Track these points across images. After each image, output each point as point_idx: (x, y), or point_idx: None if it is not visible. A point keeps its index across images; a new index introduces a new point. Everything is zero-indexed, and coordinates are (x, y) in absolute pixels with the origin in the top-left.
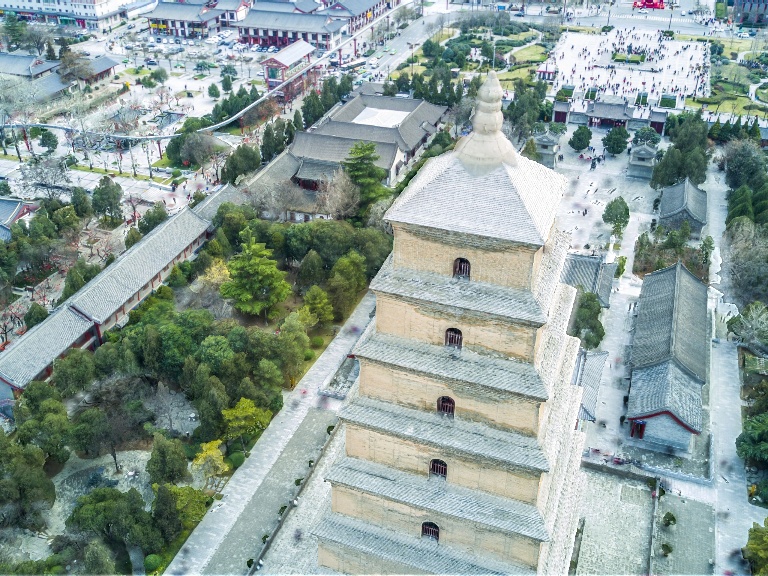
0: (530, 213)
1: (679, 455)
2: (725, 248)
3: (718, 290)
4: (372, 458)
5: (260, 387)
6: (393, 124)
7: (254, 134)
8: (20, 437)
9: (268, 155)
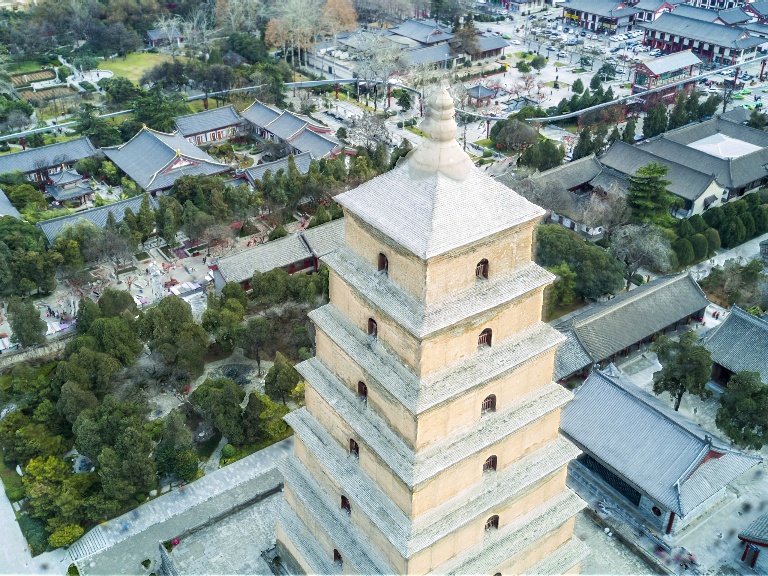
0: (436, 227)
1: None
2: None
3: None
4: (319, 418)
5: None
6: (732, 156)
7: None
8: (202, 319)
9: (578, 157)
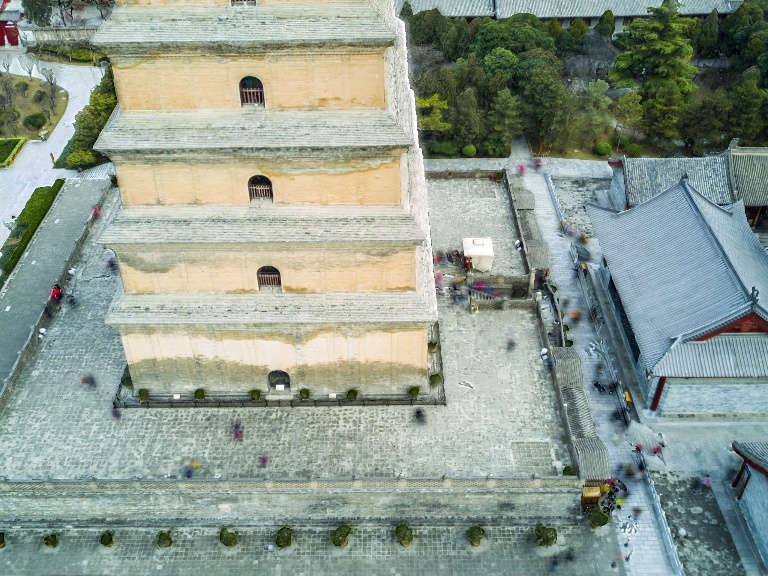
0: None
1: (746, 563)
2: None
3: None
4: None
5: (486, 115)
6: None
7: None
8: None
9: None
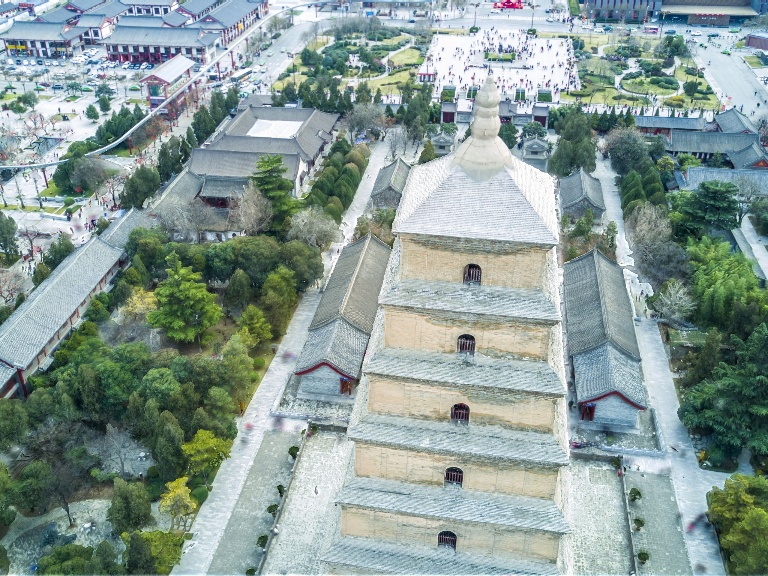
0: (538, 214)
1: (628, 432)
2: (630, 231)
3: (632, 271)
4: (384, 475)
5: (213, 416)
6: (289, 135)
7: (144, 154)
8: None
9: (165, 175)
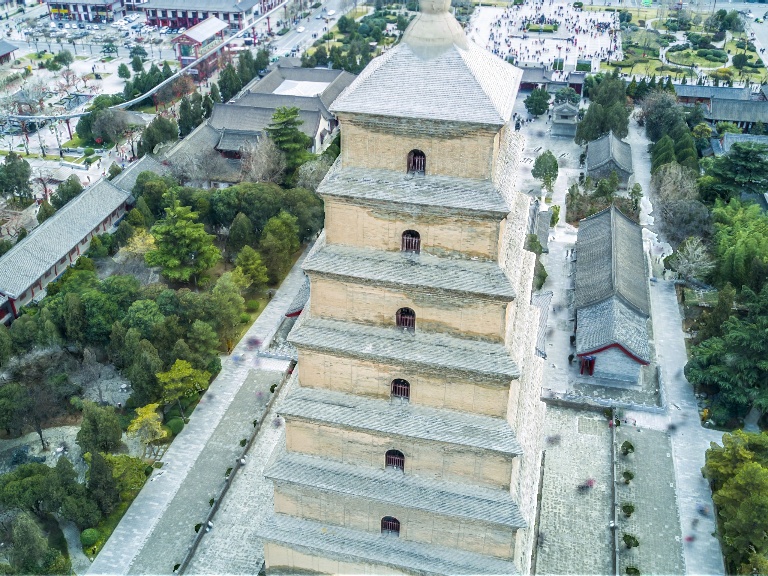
0: (487, 94)
1: (630, 388)
2: (654, 192)
3: (652, 231)
4: (328, 386)
5: (195, 350)
6: (314, 94)
7: (169, 111)
8: None
9: (186, 129)
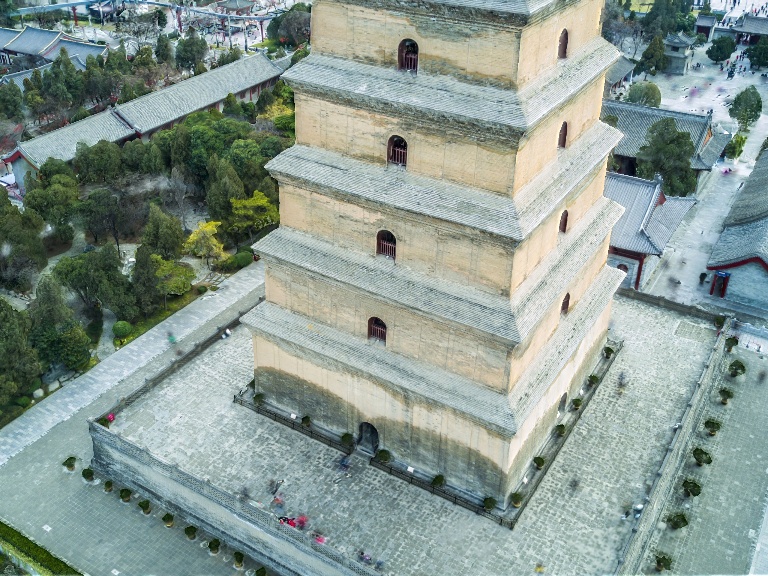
0: None
1: (767, 318)
2: None
3: None
4: (324, 144)
5: None
6: None
7: None
8: (25, 205)
9: None
